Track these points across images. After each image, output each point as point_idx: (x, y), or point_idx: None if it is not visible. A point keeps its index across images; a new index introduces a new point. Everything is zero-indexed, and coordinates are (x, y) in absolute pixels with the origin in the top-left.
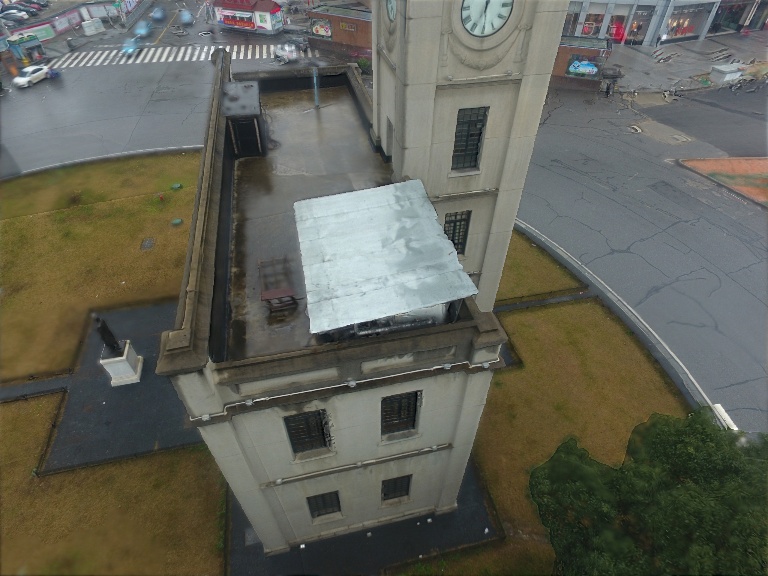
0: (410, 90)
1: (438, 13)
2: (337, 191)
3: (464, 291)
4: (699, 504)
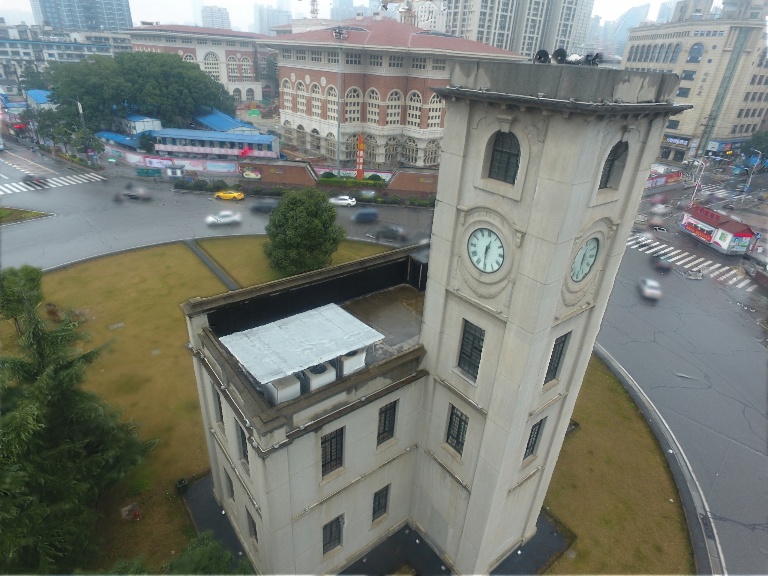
0: (430, 282)
1: (450, 239)
2: (404, 330)
3: (263, 378)
4: (133, 574)
